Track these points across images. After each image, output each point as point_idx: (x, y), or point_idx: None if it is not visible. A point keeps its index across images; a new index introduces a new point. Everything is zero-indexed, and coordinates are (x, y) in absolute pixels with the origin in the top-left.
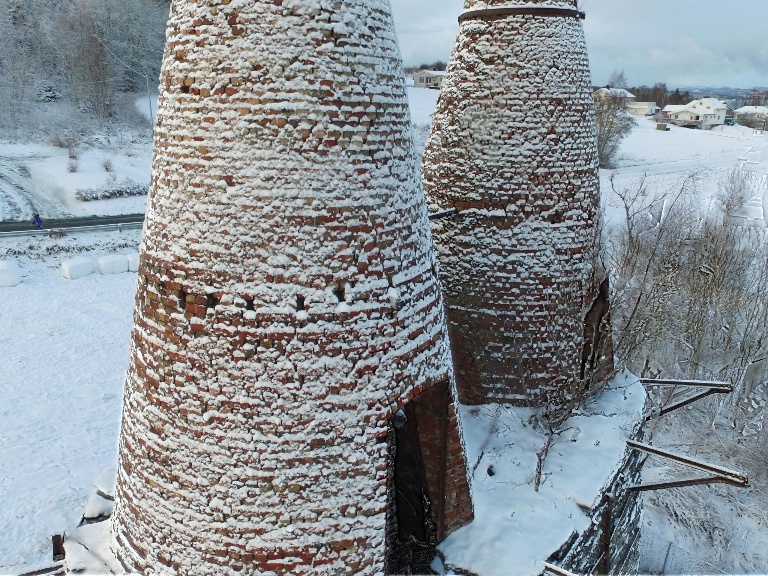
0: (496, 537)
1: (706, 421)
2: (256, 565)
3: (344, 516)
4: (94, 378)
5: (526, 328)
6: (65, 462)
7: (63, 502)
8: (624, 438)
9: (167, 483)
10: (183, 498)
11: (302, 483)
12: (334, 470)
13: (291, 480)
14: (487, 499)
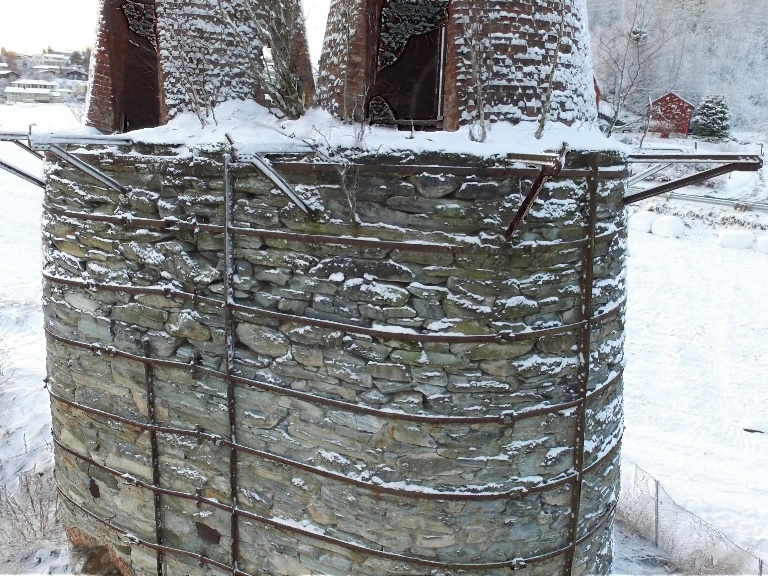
0: None
1: None
2: None
3: None
4: None
5: None
6: None
7: None
8: None
9: None
10: None
11: None
12: None
13: None
14: None
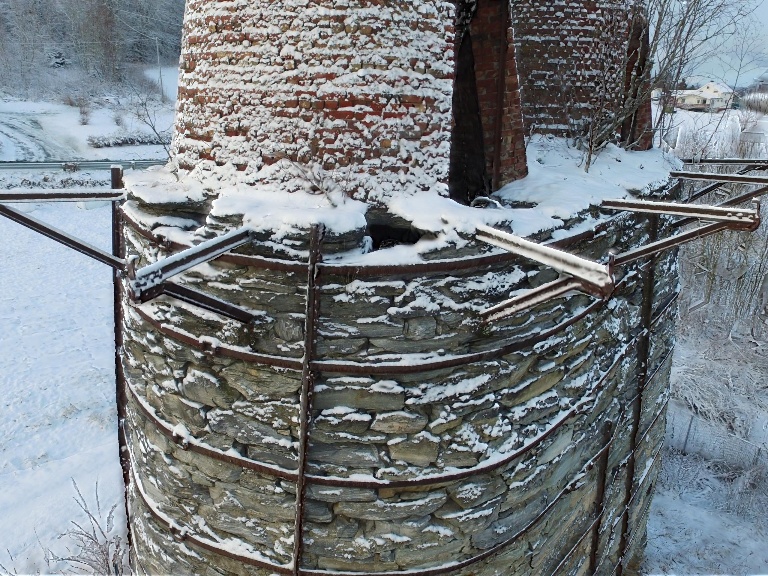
0: (551, 183)
1: (722, 335)
2: (327, 113)
3: (413, 70)
4: (112, 284)
5: (570, 54)
6: (86, 347)
7: (85, 378)
8: (667, 167)
9: (236, 46)
10: (253, 55)
11: (373, 25)
12: (404, 18)
13: (363, 21)
14: (539, 167)
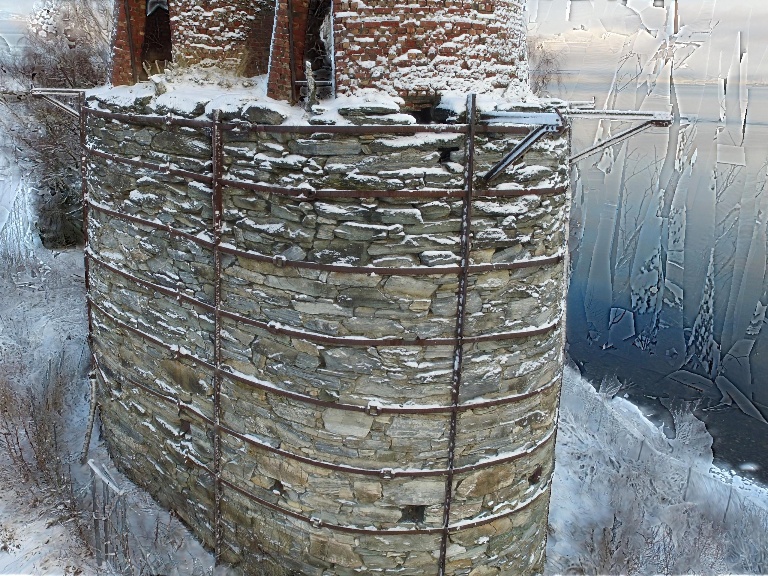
0: None
1: None
2: None
3: None
4: None
5: None
6: None
7: None
8: None
9: None
10: None
11: None
12: None
13: None
14: None
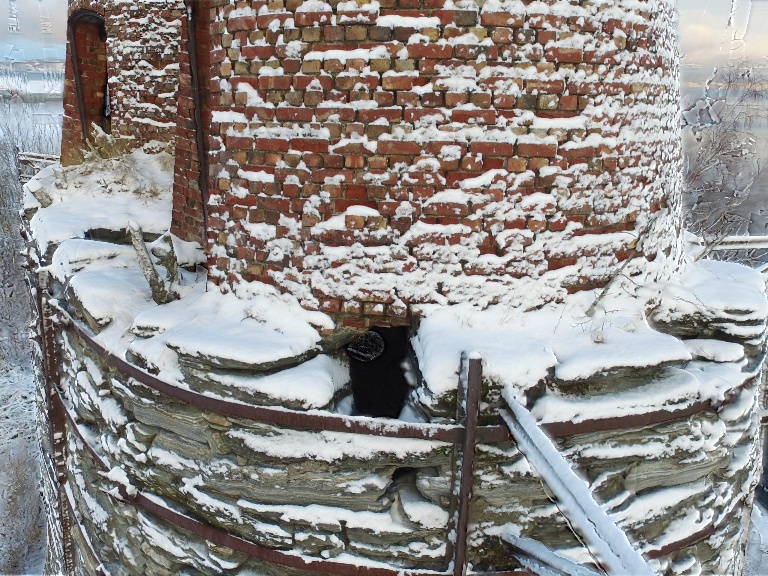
0: None
1: None
2: None
3: None
4: None
5: None
6: None
7: None
8: None
9: (653, 75)
10: None
11: None
12: None
13: None
14: None
